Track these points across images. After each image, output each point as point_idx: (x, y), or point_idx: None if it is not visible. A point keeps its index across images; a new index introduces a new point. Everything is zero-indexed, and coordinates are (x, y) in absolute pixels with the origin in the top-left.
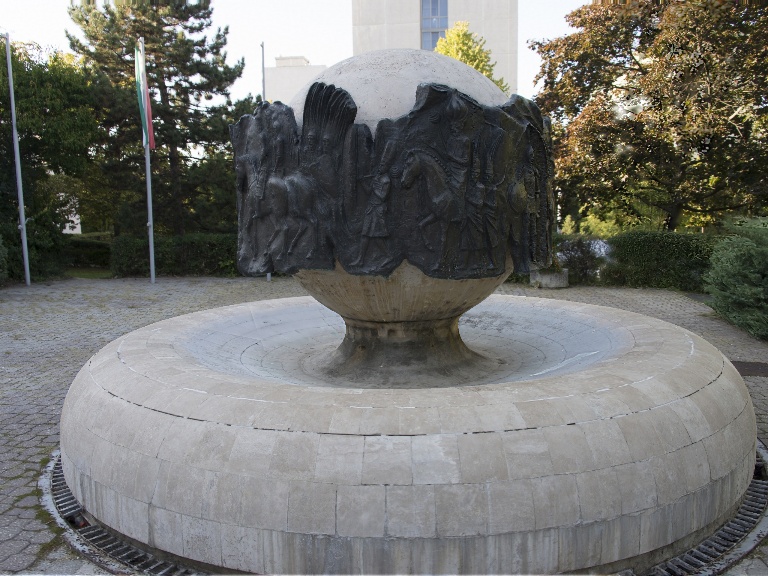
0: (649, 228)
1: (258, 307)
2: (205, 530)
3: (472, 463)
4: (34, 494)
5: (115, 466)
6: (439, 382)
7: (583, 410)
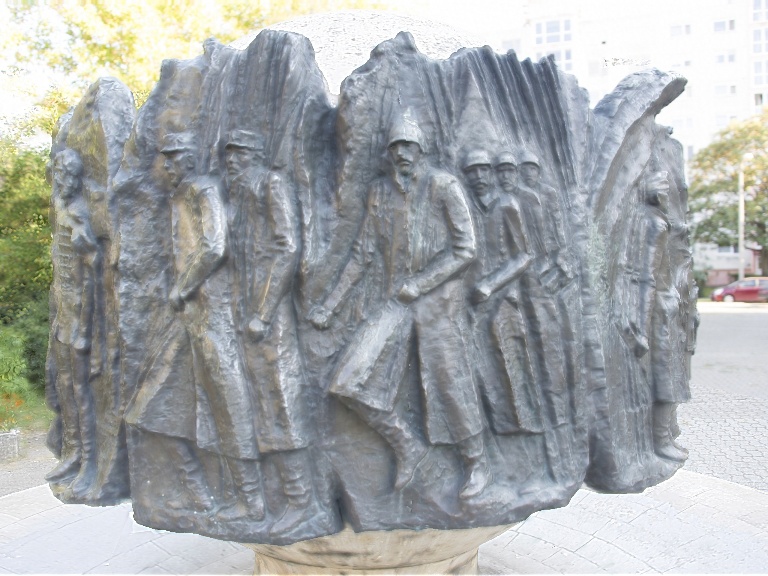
0: None
1: None
2: None
3: None
4: None
5: None
6: None
7: None
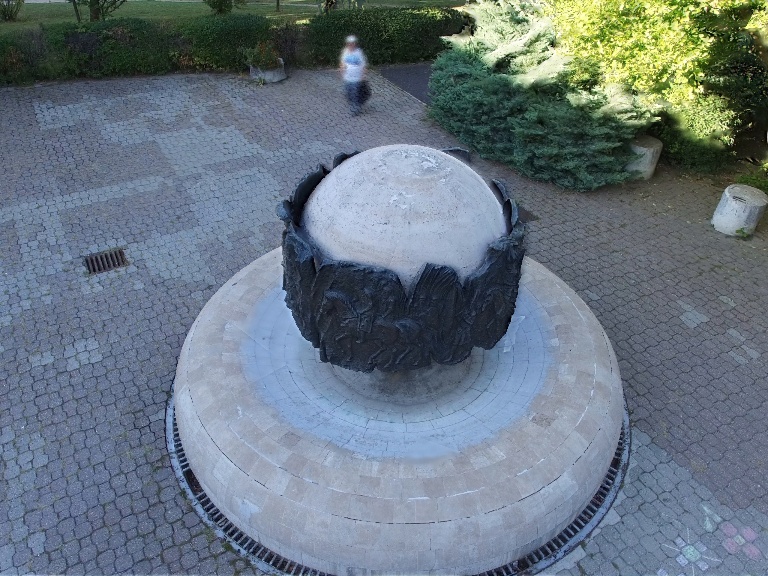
0: (342, 7)
1: (239, 321)
2: (471, 567)
3: (581, 478)
4: None
5: (395, 562)
6: (456, 375)
7: (598, 417)
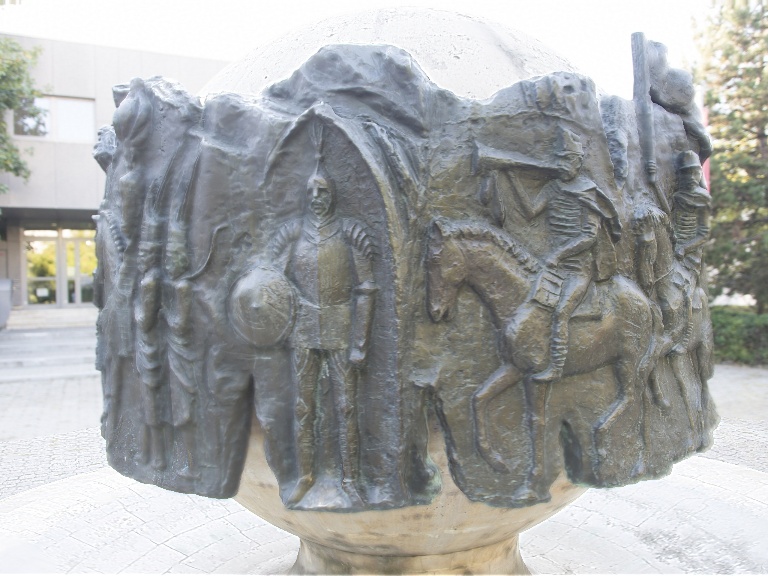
0: None
1: None
2: None
3: None
4: None
5: None
6: None
7: None
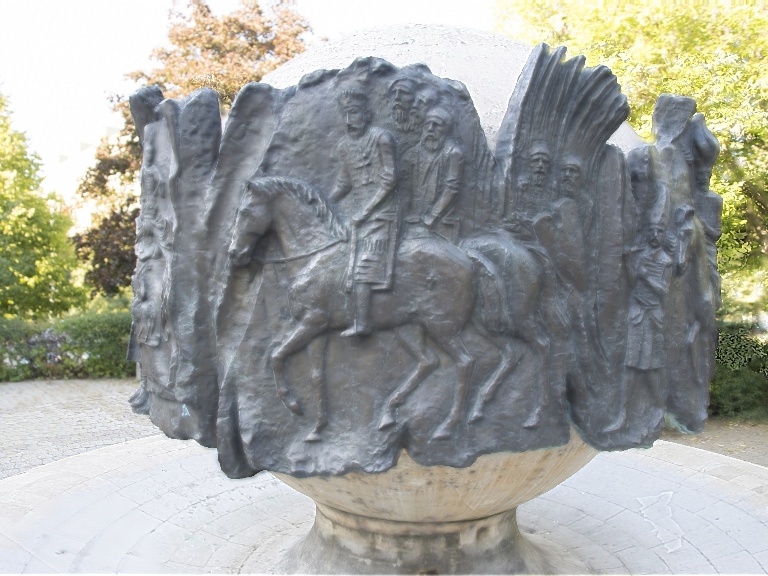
0: None
1: (2, 517)
2: None
3: None
4: None
5: None
6: None
7: None
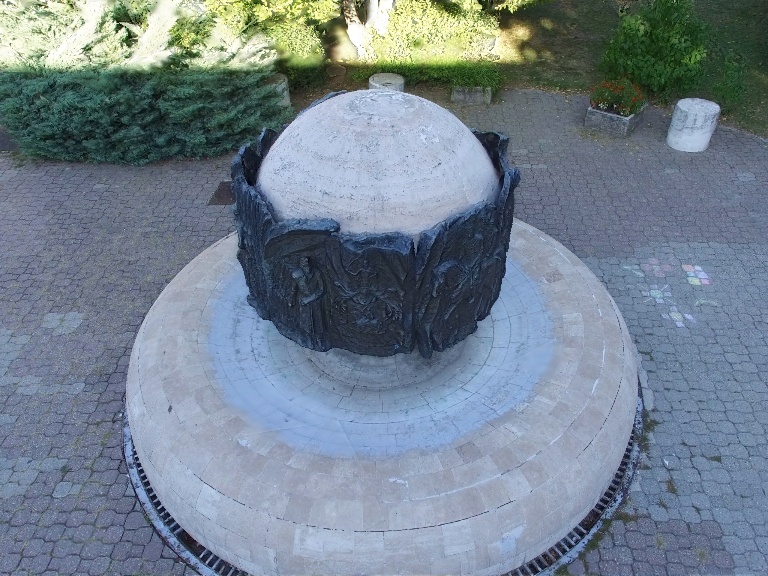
0: None
1: (244, 428)
2: None
3: None
4: (567, 570)
5: None
6: None
7: None
